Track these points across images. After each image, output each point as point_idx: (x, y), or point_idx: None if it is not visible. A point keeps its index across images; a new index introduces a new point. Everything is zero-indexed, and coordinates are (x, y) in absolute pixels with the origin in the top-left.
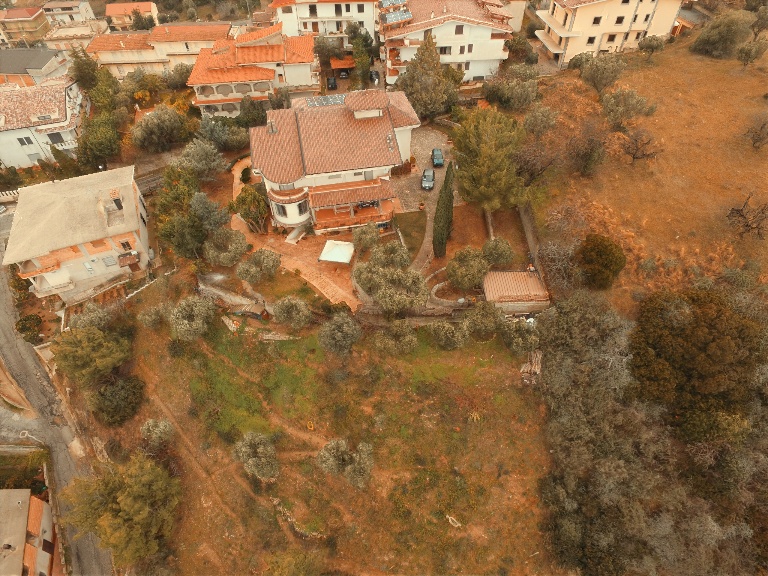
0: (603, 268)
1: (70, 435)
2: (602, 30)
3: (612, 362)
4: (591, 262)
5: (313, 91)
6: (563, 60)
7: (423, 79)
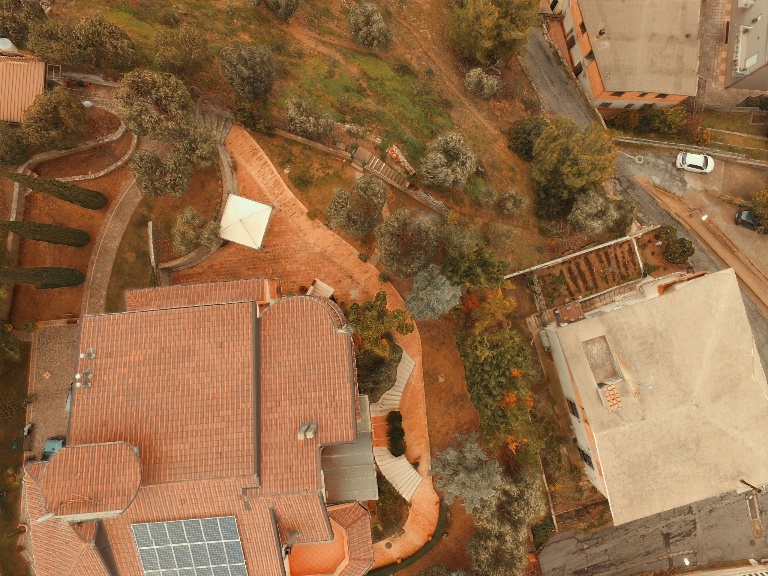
0: None
1: None
2: None
3: None
4: None
5: None
6: None
7: None
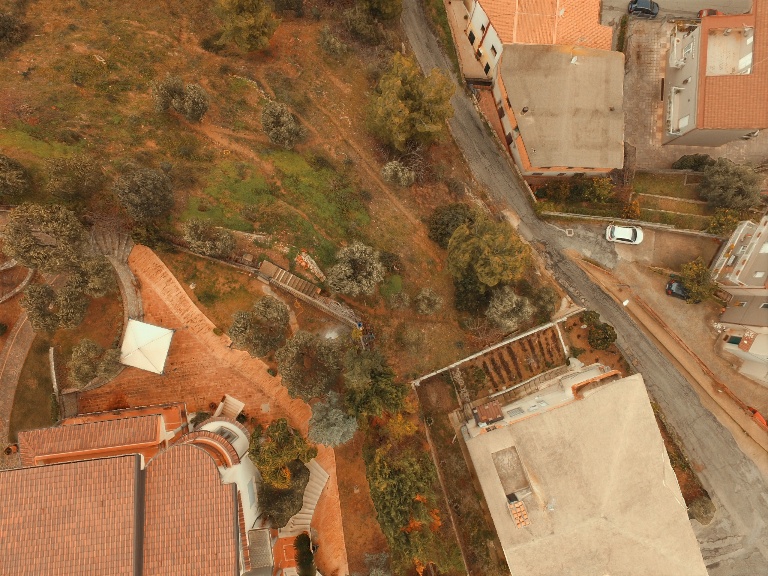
0: None
1: (523, 231)
2: None
3: None
4: None
5: None
6: None
7: None
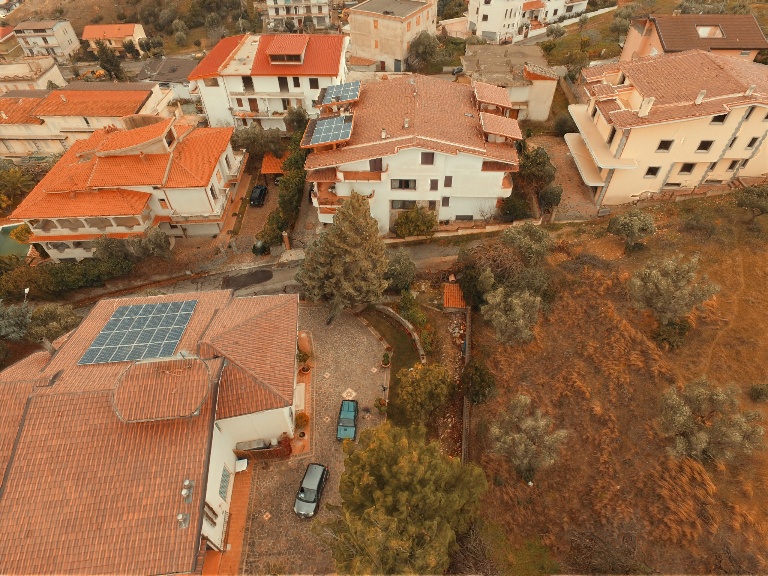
0: None
1: None
2: (672, 158)
3: None
4: None
5: (211, 223)
6: (603, 195)
7: (347, 257)
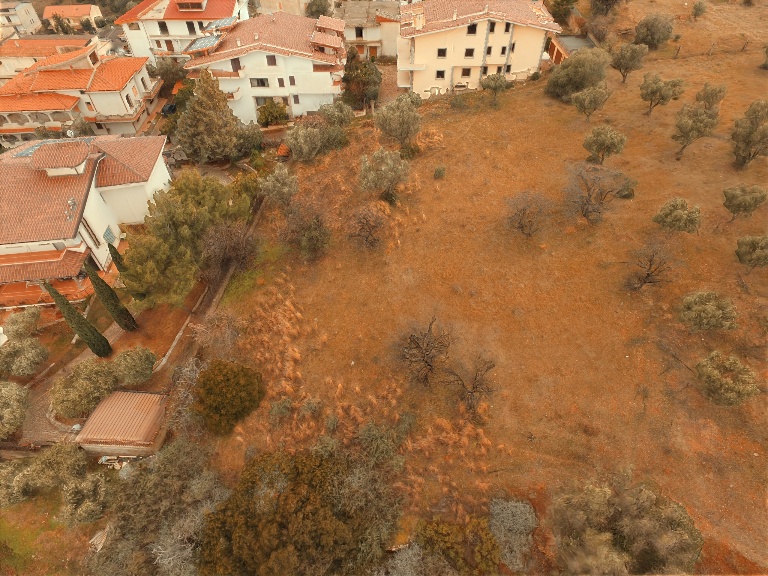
0: (213, 411)
1: None
2: (451, 63)
3: (159, 558)
4: (203, 401)
5: (127, 122)
6: None
7: None
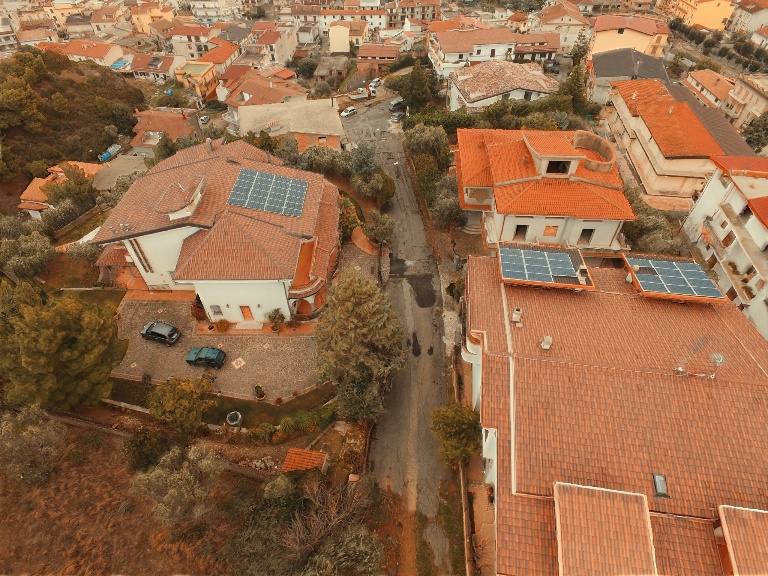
0: None
1: None
2: None
3: None
4: None
5: None
6: None
7: None
